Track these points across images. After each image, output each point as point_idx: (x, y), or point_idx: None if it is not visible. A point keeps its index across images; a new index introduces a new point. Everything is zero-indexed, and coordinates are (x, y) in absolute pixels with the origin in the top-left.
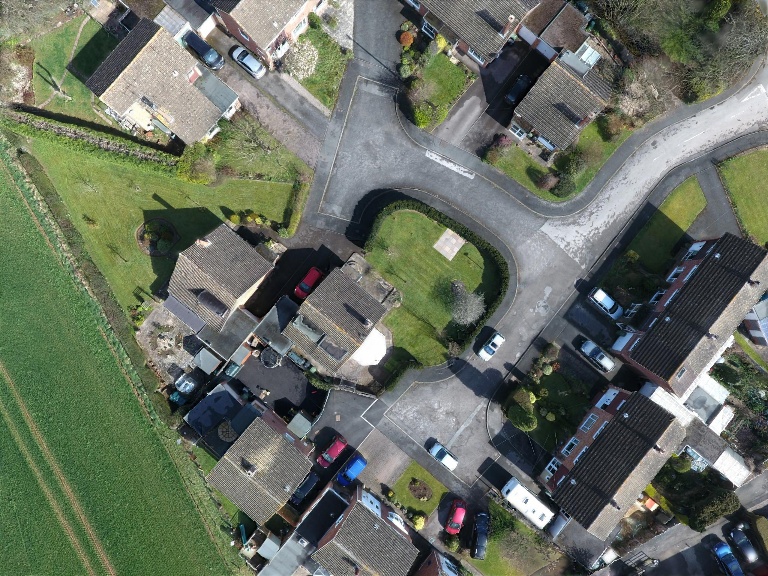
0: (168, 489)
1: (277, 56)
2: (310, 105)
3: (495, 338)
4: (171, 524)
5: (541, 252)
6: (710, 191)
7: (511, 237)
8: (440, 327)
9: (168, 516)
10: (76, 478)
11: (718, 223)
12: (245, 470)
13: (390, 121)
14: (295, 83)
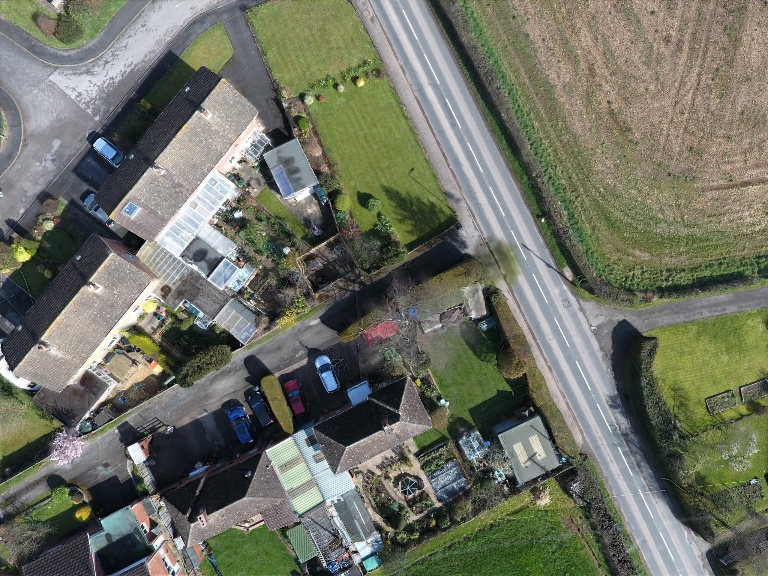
0: None
1: None
2: None
3: None
4: None
5: (49, 103)
6: (237, 39)
7: (16, 87)
8: None
9: None
10: None
11: (246, 73)
12: None
13: None
14: None
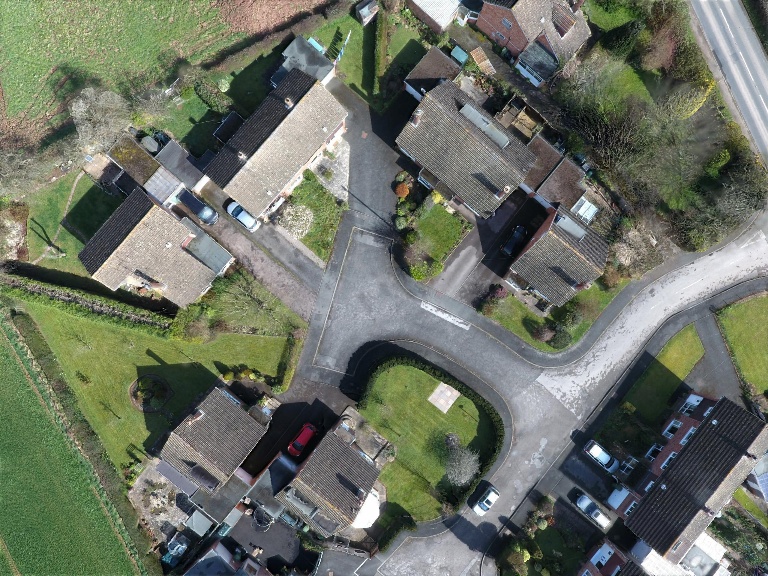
0: None
1: (272, 211)
2: (305, 257)
3: (490, 495)
4: None
5: (537, 403)
6: (708, 339)
7: (506, 388)
8: (434, 481)
9: None
10: None
11: (716, 372)
12: None
13: (385, 272)
14: None
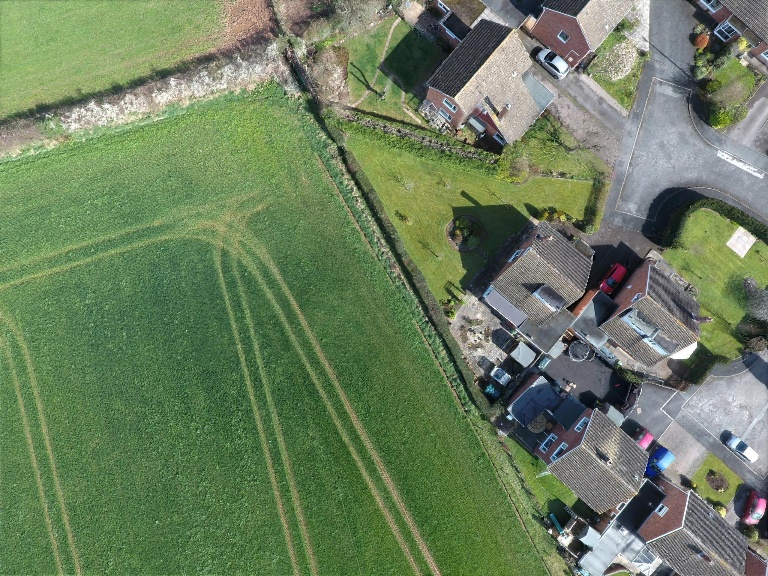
0: (482, 478)
1: None
2: (608, 105)
3: None
4: (485, 512)
5: None
6: None
7: None
8: (734, 322)
9: (482, 505)
10: (396, 467)
11: None
12: (601, 459)
13: (683, 121)
14: (594, 84)
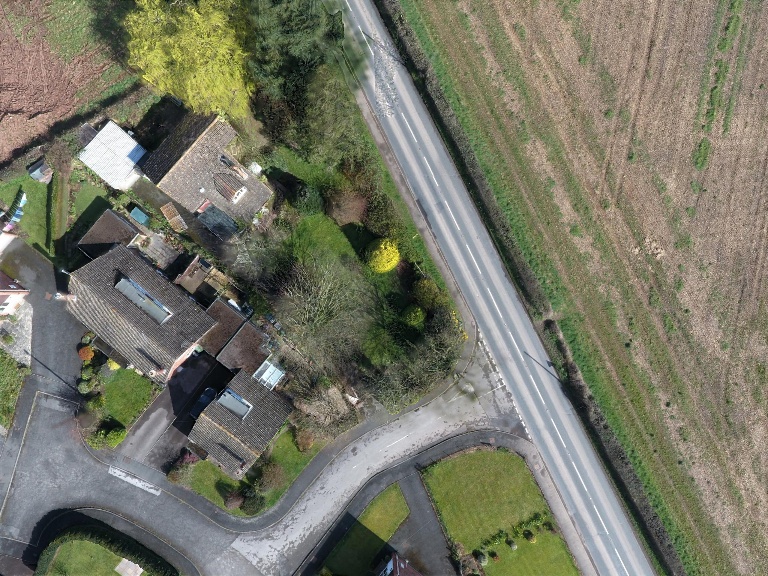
0: None
1: None
2: None
3: None
4: None
5: (231, 570)
6: (413, 499)
7: (199, 555)
8: None
9: None
10: None
11: (421, 532)
12: None
13: (71, 437)
14: None
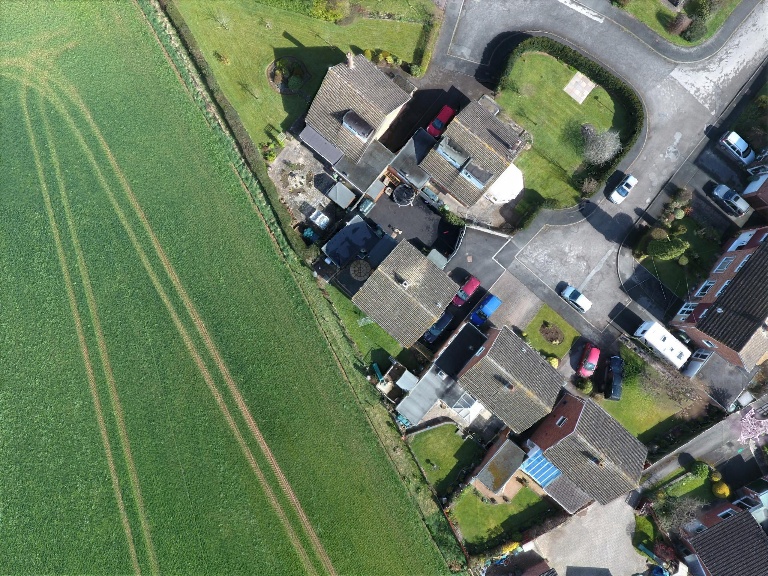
0: (301, 326)
1: None
2: None
3: (629, 179)
4: (304, 361)
5: (671, 97)
6: None
7: (641, 82)
8: (571, 170)
9: (301, 353)
10: (210, 313)
11: None
12: (399, 283)
13: None
14: None
